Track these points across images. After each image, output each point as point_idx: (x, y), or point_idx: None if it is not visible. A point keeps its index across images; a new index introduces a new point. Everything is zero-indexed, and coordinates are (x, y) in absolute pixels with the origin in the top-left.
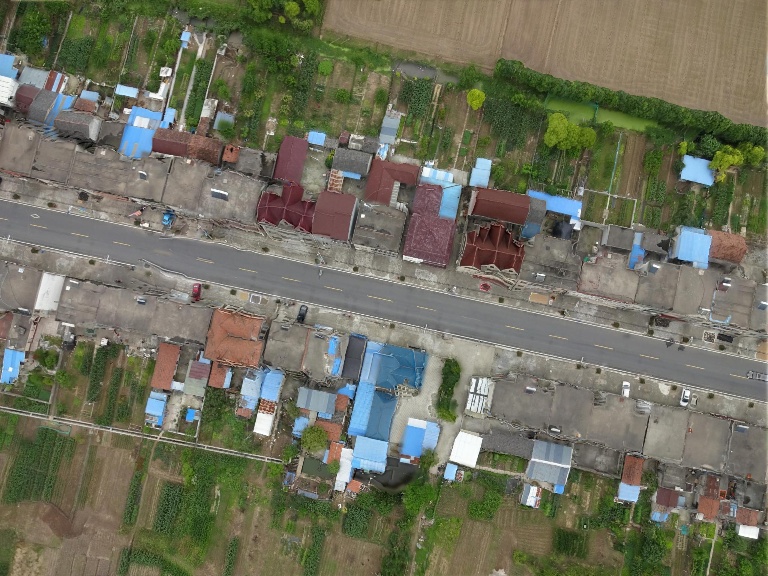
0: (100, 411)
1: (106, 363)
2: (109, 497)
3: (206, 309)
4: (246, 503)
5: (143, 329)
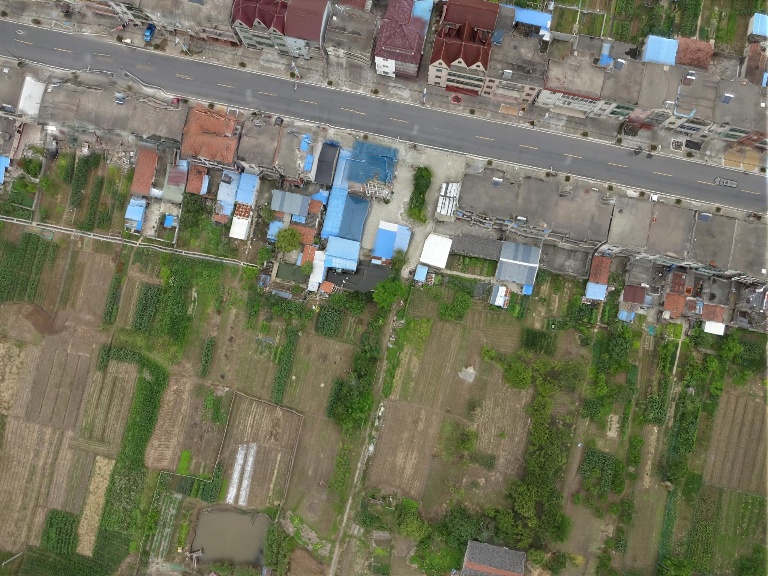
0: (81, 217)
1: (87, 171)
2: (90, 299)
3: (182, 108)
4: (222, 306)
5: (121, 128)
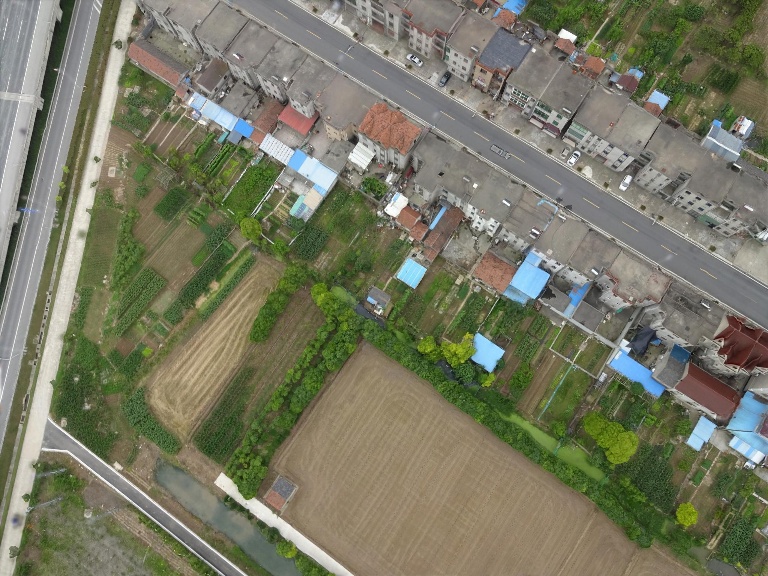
0: None
1: None
2: None
3: None
4: None
5: None
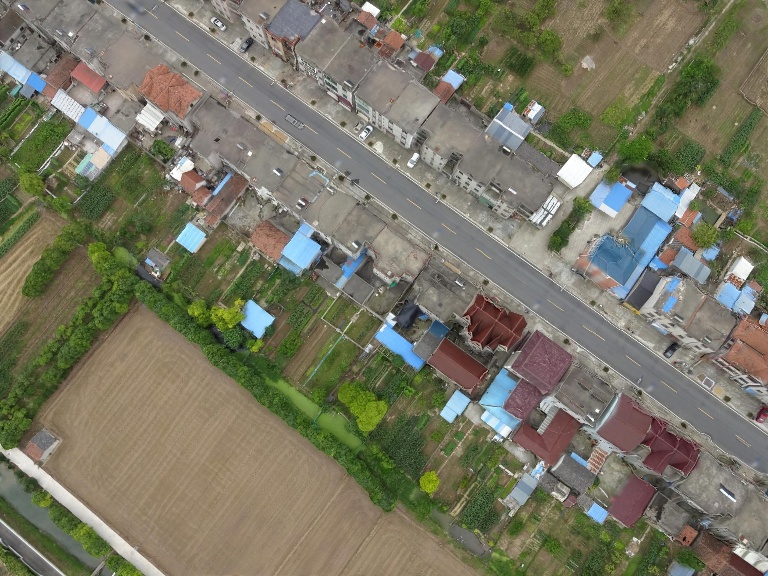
0: None
1: None
2: None
3: None
4: None
5: None
